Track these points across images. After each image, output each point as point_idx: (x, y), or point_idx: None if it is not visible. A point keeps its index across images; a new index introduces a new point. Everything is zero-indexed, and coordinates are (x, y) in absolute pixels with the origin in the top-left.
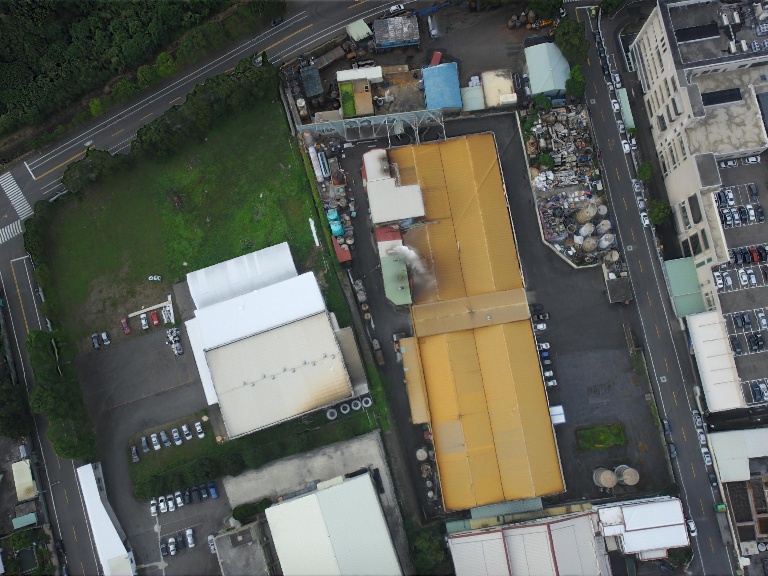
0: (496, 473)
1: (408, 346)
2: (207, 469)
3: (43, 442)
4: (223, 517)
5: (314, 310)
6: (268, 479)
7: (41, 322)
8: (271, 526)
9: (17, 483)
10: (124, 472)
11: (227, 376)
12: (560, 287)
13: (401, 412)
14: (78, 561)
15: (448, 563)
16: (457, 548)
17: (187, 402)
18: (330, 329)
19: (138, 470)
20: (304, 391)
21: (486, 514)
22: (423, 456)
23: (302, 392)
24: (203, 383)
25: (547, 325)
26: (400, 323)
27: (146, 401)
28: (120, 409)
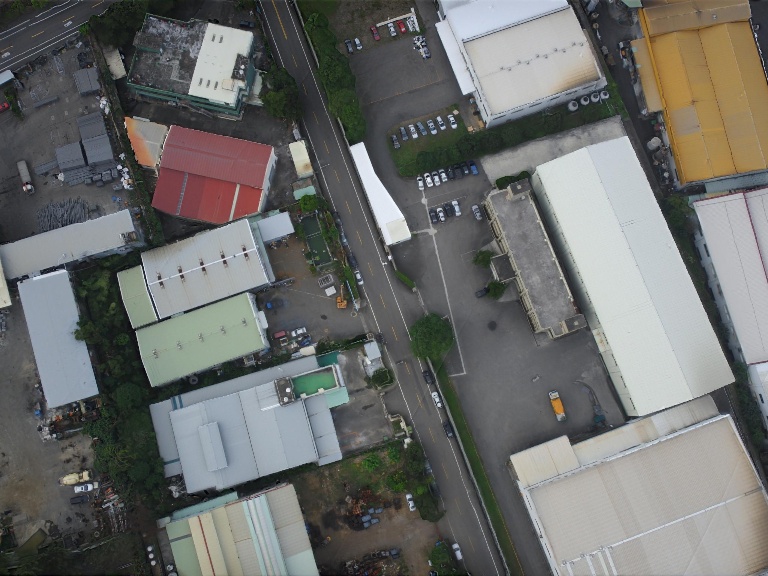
0: (728, 151)
1: (639, 46)
2: (473, 142)
3: (310, 131)
4: (484, 191)
5: (559, 7)
6: (523, 157)
7: (297, 29)
8: (543, 180)
9: (295, 160)
10: (387, 157)
11: (485, 63)
12: (767, 3)
13: (630, 110)
14: (354, 230)
15: (695, 221)
16: (702, 209)
17: (438, 98)
18: (577, 21)
19: (399, 155)
20: (557, 74)
21: (719, 189)
22: (658, 142)
23: (555, 75)
24: (457, 76)
25: (757, 35)
26: (624, 34)
27: (400, 98)
28: (377, 105)
